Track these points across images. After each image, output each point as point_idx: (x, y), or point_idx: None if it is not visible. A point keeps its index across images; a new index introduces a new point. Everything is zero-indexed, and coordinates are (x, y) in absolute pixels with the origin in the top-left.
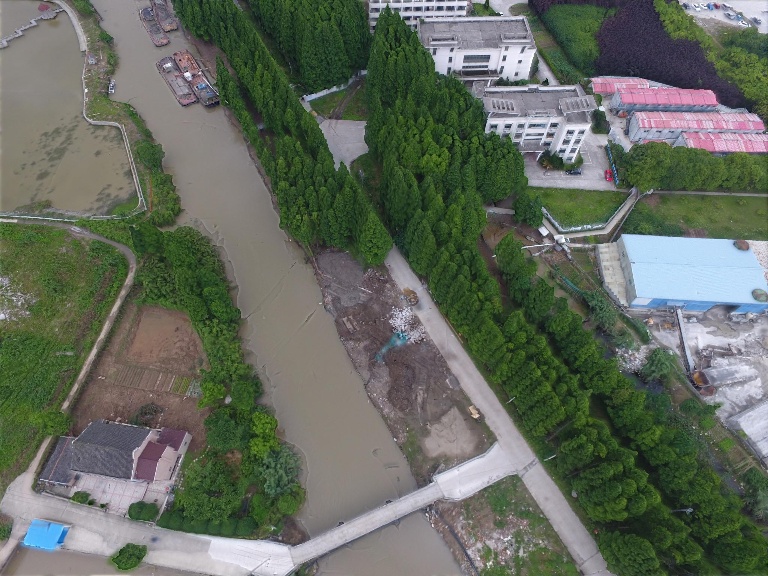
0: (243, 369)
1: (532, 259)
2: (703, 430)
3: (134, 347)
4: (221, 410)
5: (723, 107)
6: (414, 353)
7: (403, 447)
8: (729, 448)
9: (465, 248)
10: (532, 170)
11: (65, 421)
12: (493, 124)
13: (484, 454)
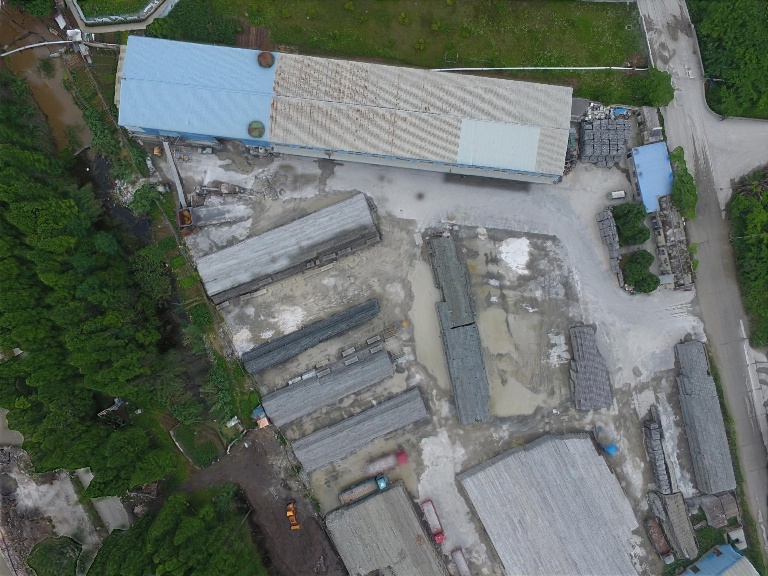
0: None
1: (50, 61)
2: (172, 268)
3: None
4: None
5: None
6: None
7: None
8: (188, 285)
9: None
10: None
11: None
12: None
13: None
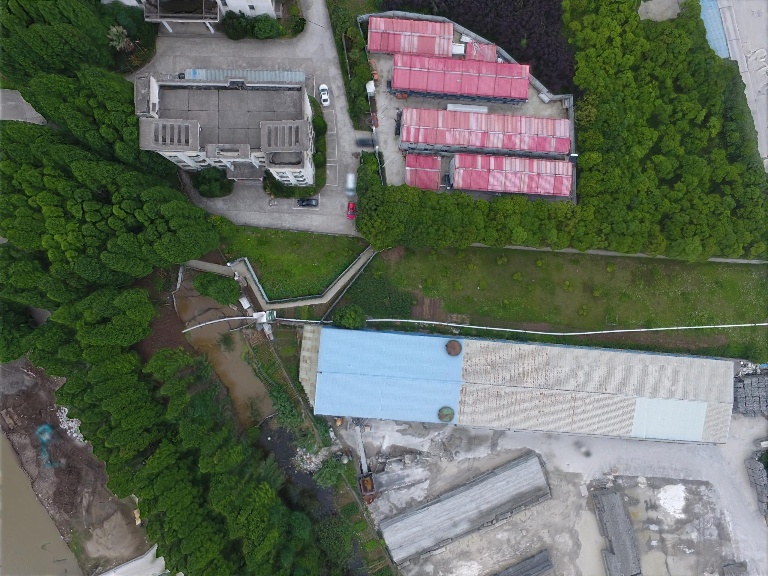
0: None
1: (230, 335)
2: (355, 531)
3: None
4: None
5: (544, 89)
6: (81, 453)
7: (69, 544)
8: (371, 549)
9: (90, 387)
10: (254, 195)
11: None
12: (168, 155)
13: (142, 556)
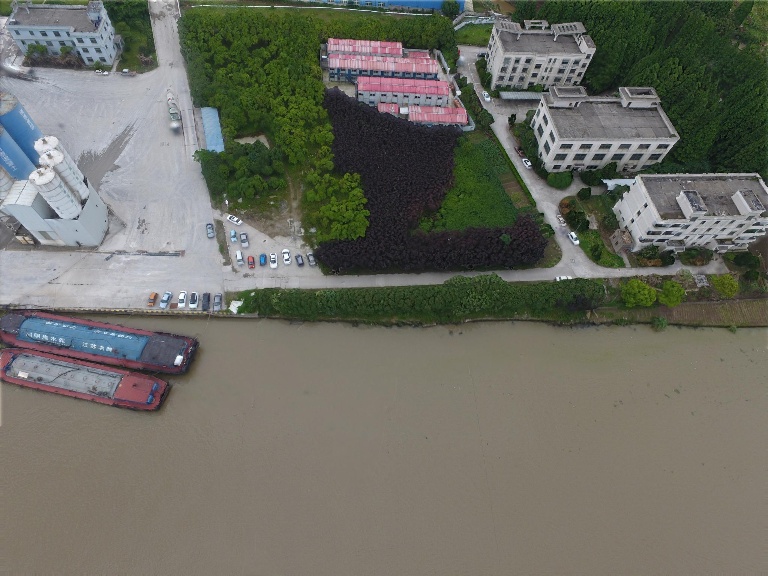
0: None
1: None
2: None
3: None
4: None
5: None
6: None
7: None
8: None
9: None
10: None
11: None
12: None
13: None
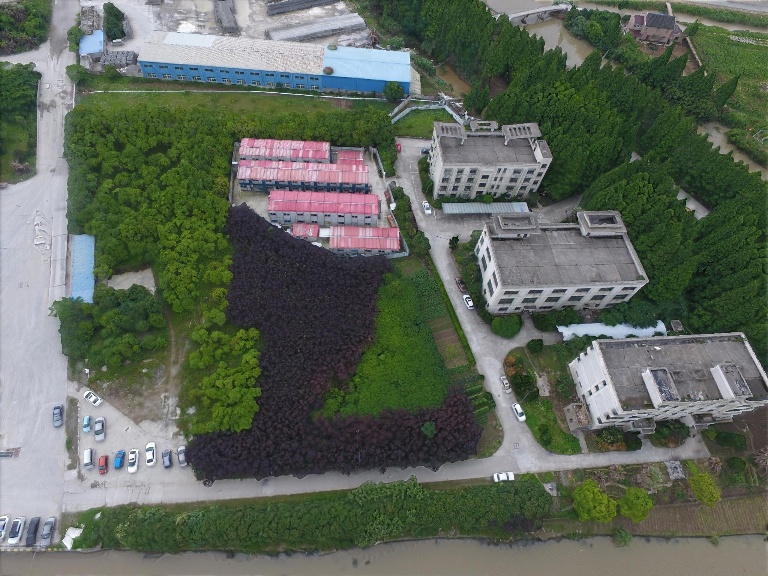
0: (620, 49)
1: None
2: None
3: (684, 73)
4: (619, 41)
5: None
6: None
7: None
8: None
9: None
10: None
11: (687, 31)
12: None
13: None
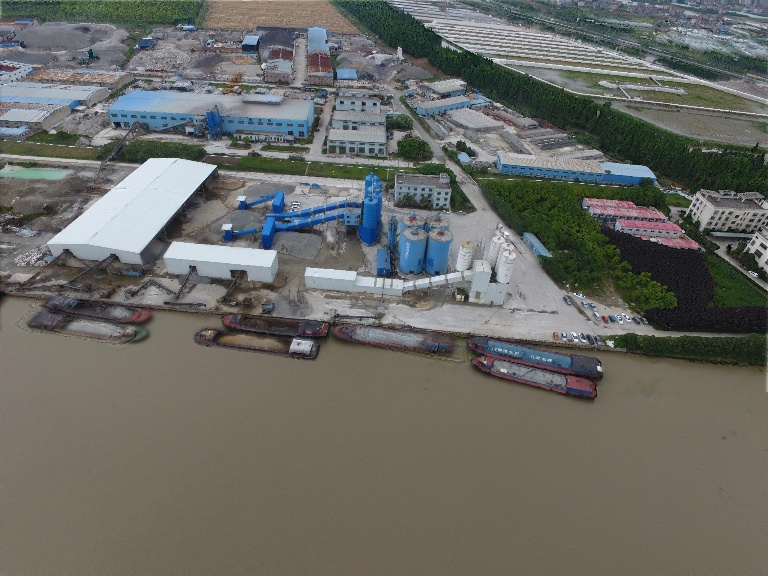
0: None
1: None
2: None
3: None
4: None
5: None
6: None
7: None
8: None
9: None
10: None
11: None
12: None
13: None
